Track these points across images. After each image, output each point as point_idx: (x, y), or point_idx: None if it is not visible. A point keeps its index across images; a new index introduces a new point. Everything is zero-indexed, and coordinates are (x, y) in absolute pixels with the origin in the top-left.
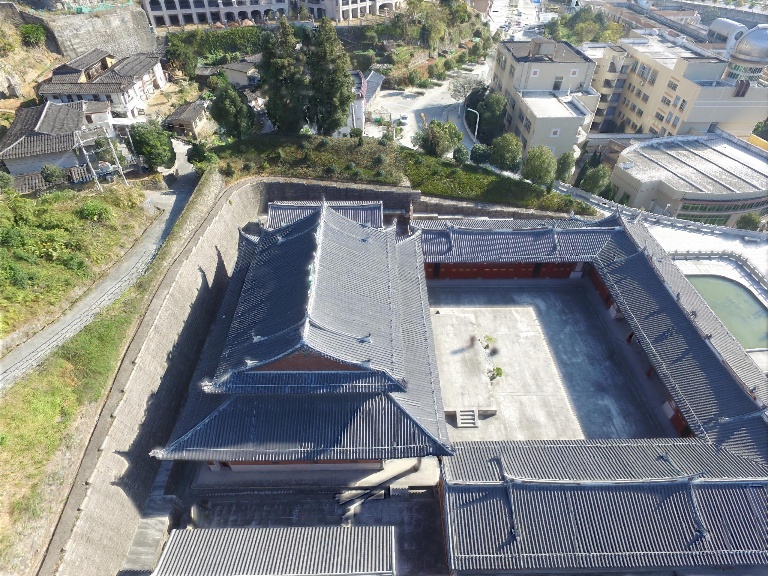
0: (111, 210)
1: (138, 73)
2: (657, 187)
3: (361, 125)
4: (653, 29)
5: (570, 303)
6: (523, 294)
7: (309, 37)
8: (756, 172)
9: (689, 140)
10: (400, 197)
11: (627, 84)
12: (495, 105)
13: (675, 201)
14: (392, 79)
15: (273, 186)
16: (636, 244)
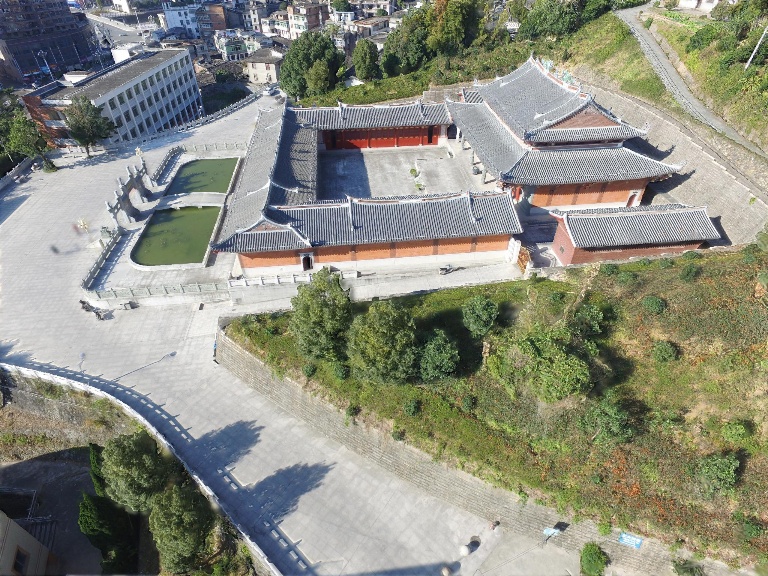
0: None
1: None
2: None
3: None
4: None
5: None
6: None
7: None
8: None
9: None
10: None
11: None
12: None
13: None
14: None
15: None
16: None
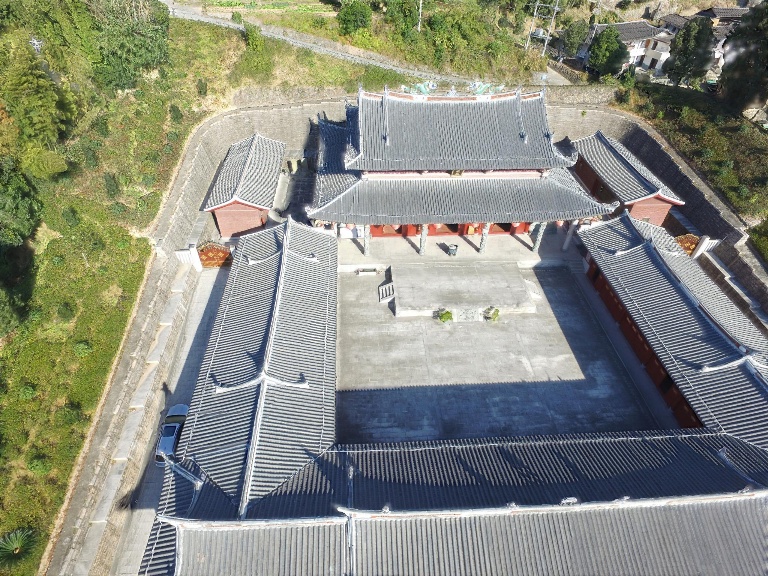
0: (501, 52)
1: None
2: None
3: None
4: None
5: None
6: (611, 372)
7: None
8: None
9: None
10: (719, 224)
11: None
12: None
13: None
14: None
15: (640, 134)
16: None
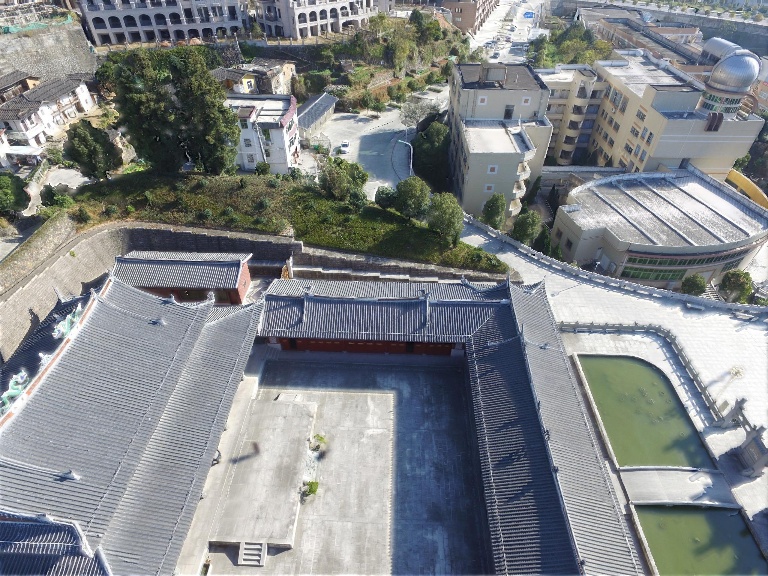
0: None
1: (51, 97)
2: (602, 235)
3: (285, 155)
4: (637, 49)
5: (440, 390)
6: (389, 375)
7: (177, 69)
8: (723, 219)
9: (655, 178)
10: (279, 248)
11: (601, 110)
12: (435, 136)
13: (620, 252)
14: (346, 101)
15: (136, 233)
16: (516, 325)
